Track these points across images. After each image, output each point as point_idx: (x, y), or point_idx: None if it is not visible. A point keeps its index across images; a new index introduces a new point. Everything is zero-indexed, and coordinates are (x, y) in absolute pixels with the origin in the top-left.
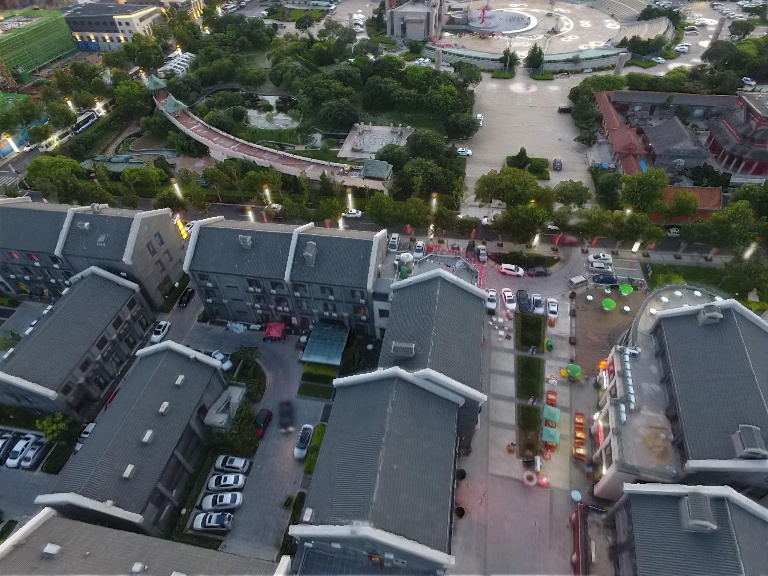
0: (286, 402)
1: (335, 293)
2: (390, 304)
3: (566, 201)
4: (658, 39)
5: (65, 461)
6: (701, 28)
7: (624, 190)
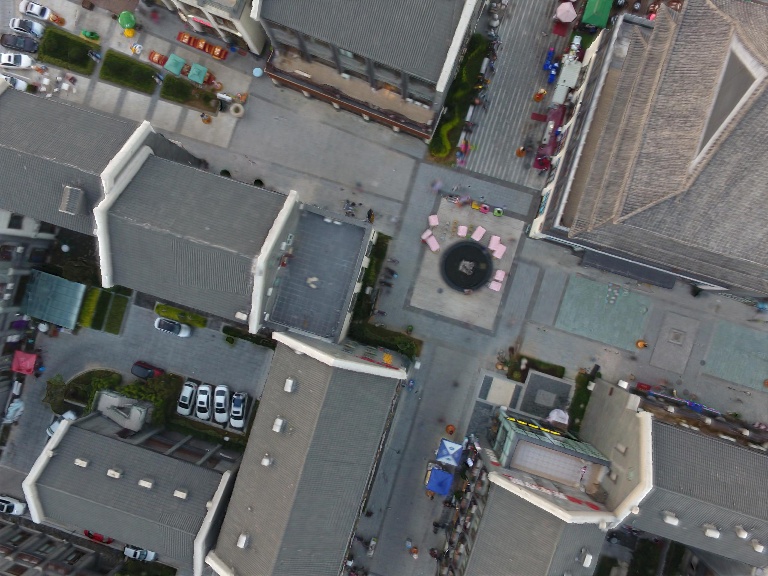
0: (126, 347)
1: None
2: (1, 212)
3: None
4: None
5: (163, 567)
6: None
7: None
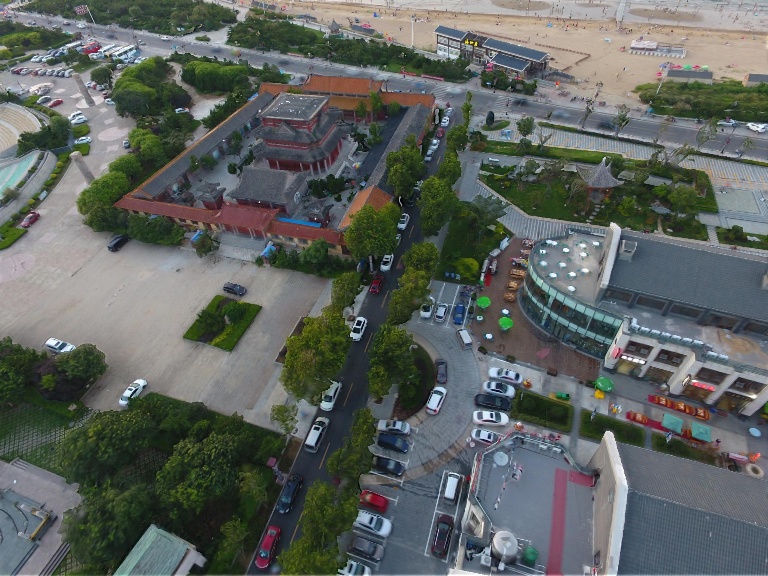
0: None
1: None
2: None
3: (351, 301)
4: (57, 123)
5: None
6: (50, 95)
7: (371, 245)
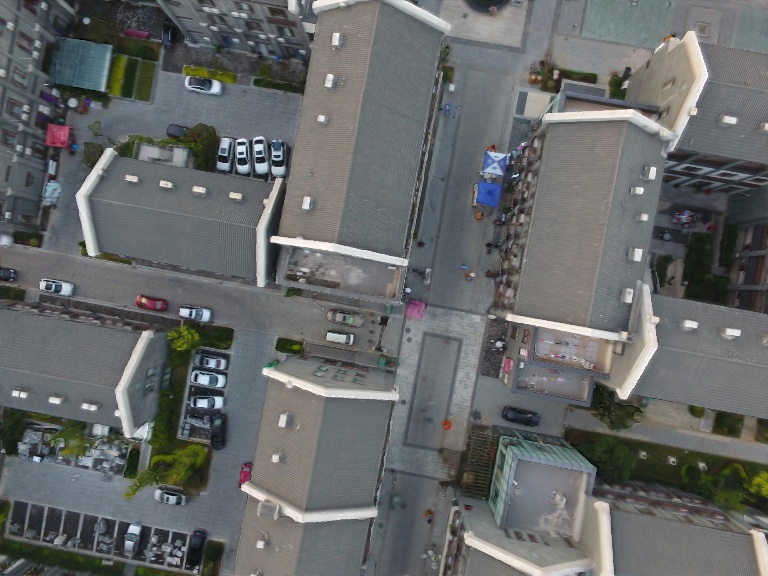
0: (158, 114)
1: (2, 16)
2: None
3: None
4: None
5: None
6: None
7: None
